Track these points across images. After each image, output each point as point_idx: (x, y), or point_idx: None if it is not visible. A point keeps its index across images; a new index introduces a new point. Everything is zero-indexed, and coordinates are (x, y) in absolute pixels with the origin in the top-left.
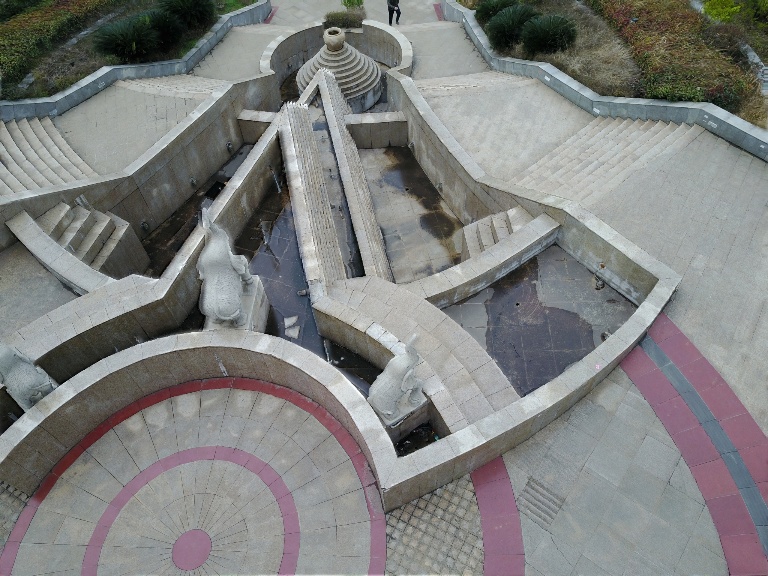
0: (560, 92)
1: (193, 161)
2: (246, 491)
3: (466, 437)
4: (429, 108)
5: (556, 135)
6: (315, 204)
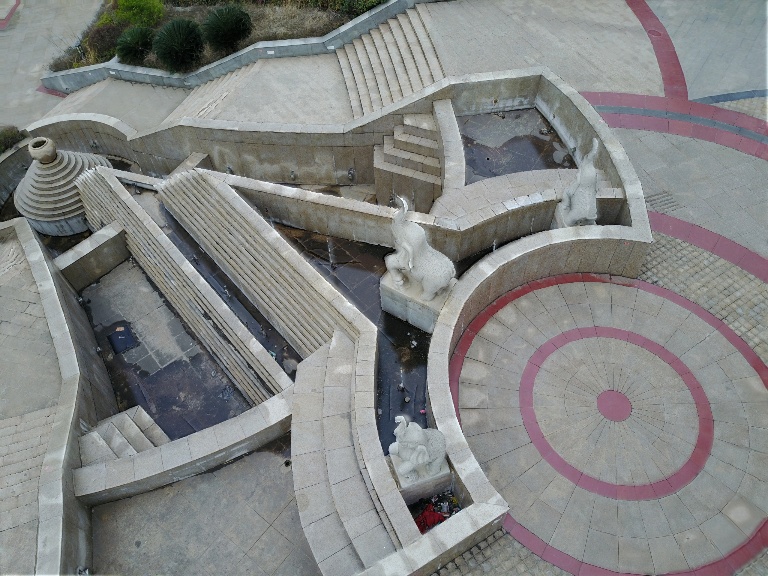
0: (289, 55)
1: (82, 330)
2: (580, 354)
3: (633, 189)
4: (235, 122)
5: (330, 79)
6: None
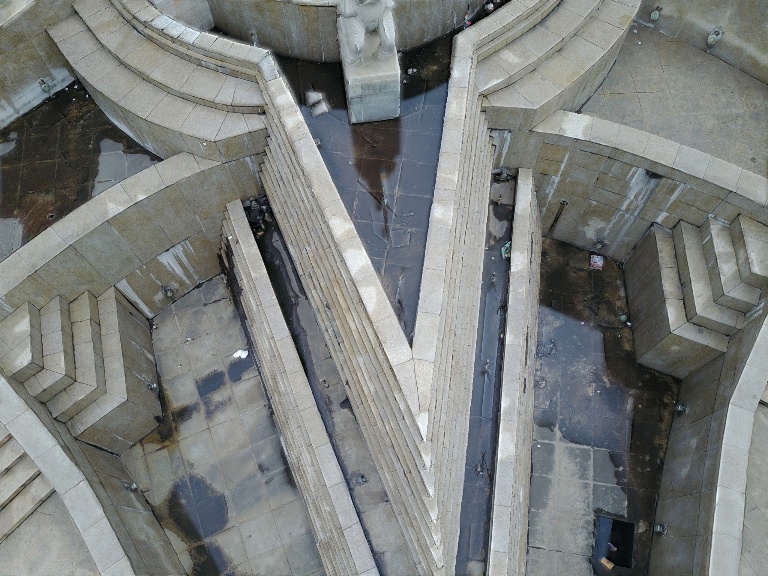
0: None
1: None
2: None
3: None
4: None
5: None
6: (318, 247)
